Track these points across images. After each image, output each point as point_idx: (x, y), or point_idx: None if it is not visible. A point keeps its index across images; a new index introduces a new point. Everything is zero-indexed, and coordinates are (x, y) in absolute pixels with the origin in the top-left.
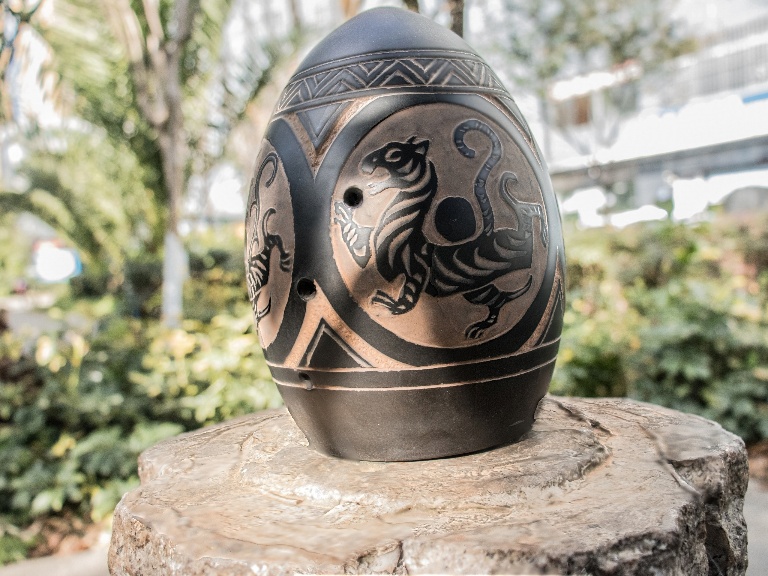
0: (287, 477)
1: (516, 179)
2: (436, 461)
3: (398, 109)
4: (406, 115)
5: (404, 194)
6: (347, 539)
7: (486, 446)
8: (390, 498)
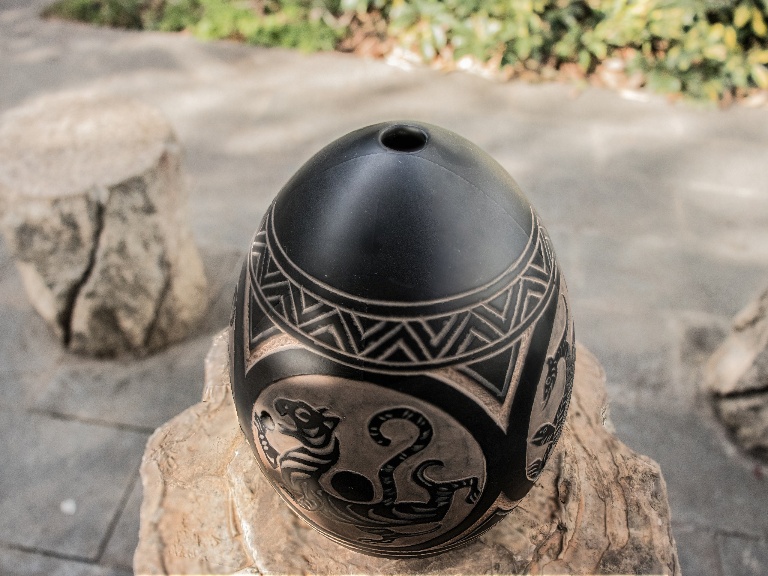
0: (249, 494)
1: (442, 464)
2: None
3: (318, 372)
4: (324, 383)
5: (306, 450)
6: None
7: None
8: None
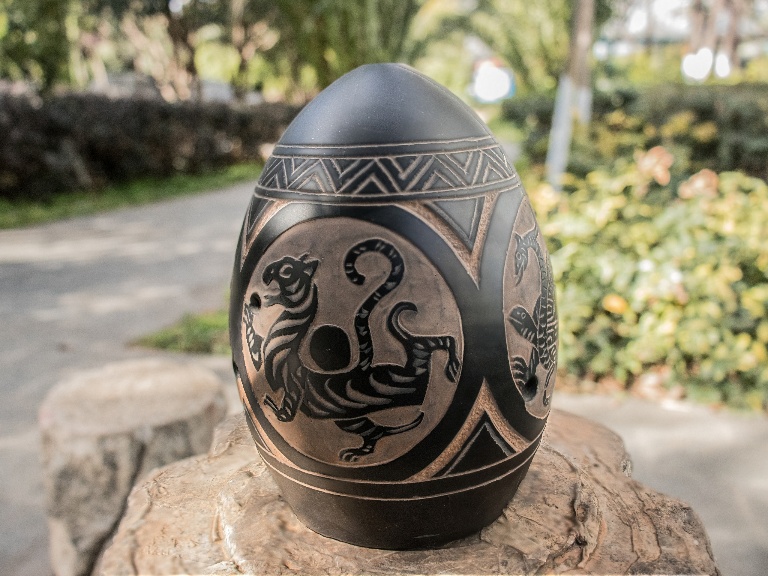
0: (236, 507)
1: (416, 309)
2: (340, 544)
3: (301, 220)
4: (306, 228)
5: (287, 313)
6: None
7: (391, 547)
8: (256, 575)
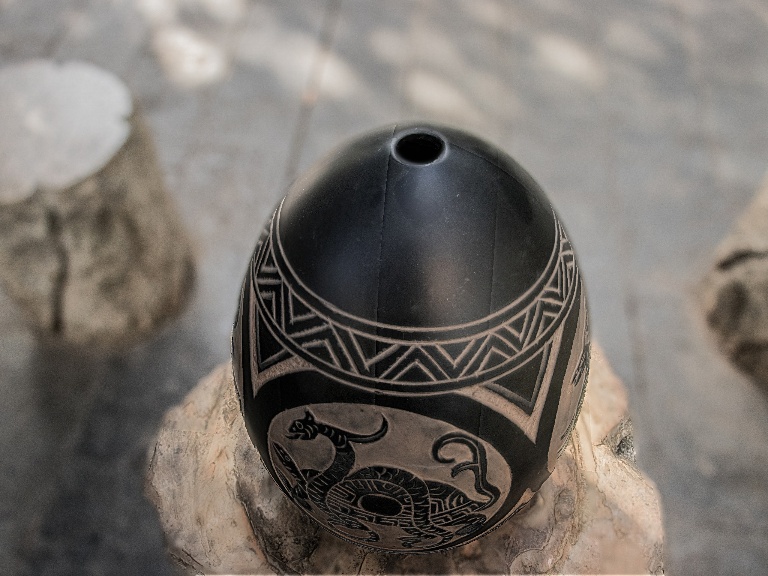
0: None
1: None
2: None
3: None
4: None
5: None
6: None
7: None
8: None
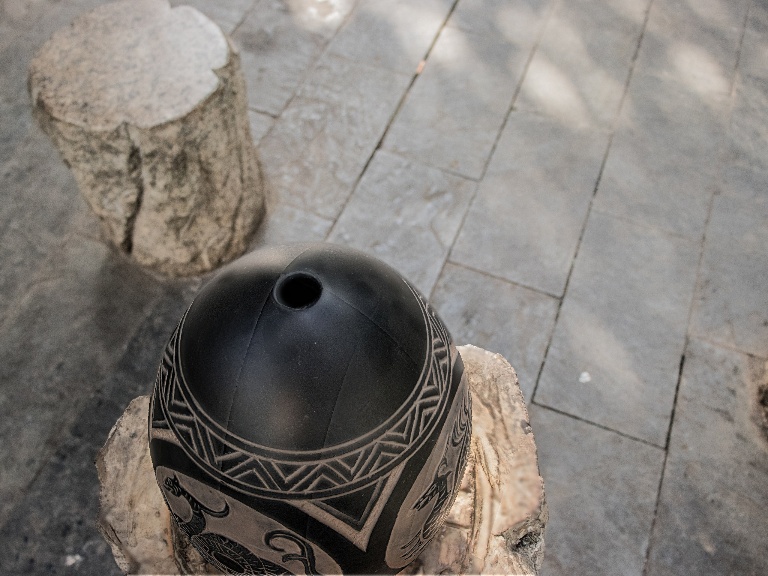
0: None
1: None
2: None
3: None
4: None
5: None
6: None
7: None
8: None
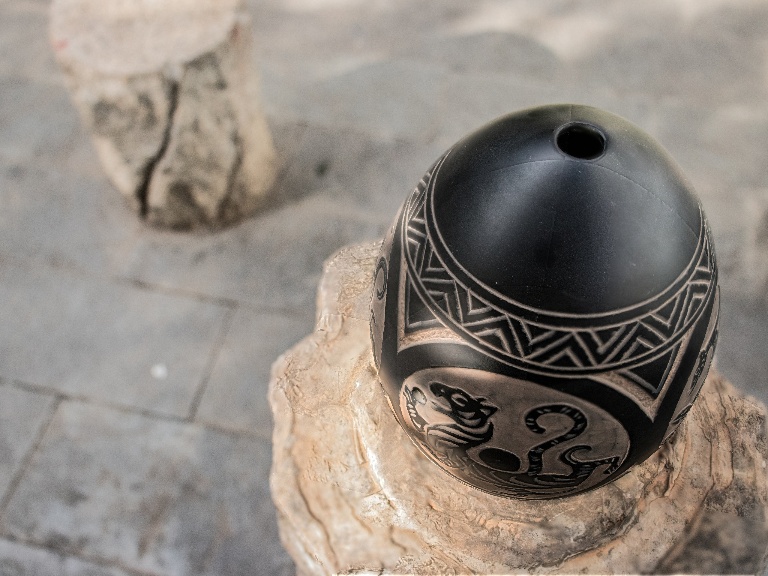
0: (372, 425)
1: (590, 448)
2: None
3: (480, 368)
4: (486, 377)
5: (458, 427)
6: (357, 543)
7: None
8: (408, 515)
